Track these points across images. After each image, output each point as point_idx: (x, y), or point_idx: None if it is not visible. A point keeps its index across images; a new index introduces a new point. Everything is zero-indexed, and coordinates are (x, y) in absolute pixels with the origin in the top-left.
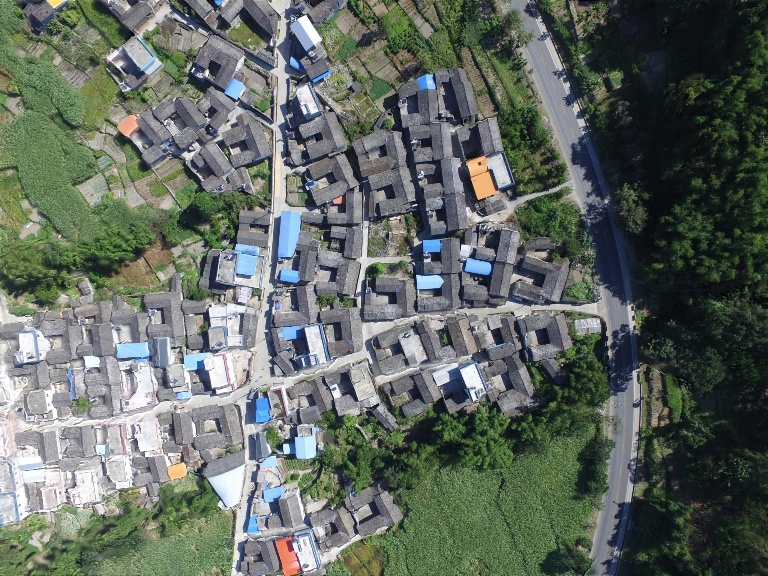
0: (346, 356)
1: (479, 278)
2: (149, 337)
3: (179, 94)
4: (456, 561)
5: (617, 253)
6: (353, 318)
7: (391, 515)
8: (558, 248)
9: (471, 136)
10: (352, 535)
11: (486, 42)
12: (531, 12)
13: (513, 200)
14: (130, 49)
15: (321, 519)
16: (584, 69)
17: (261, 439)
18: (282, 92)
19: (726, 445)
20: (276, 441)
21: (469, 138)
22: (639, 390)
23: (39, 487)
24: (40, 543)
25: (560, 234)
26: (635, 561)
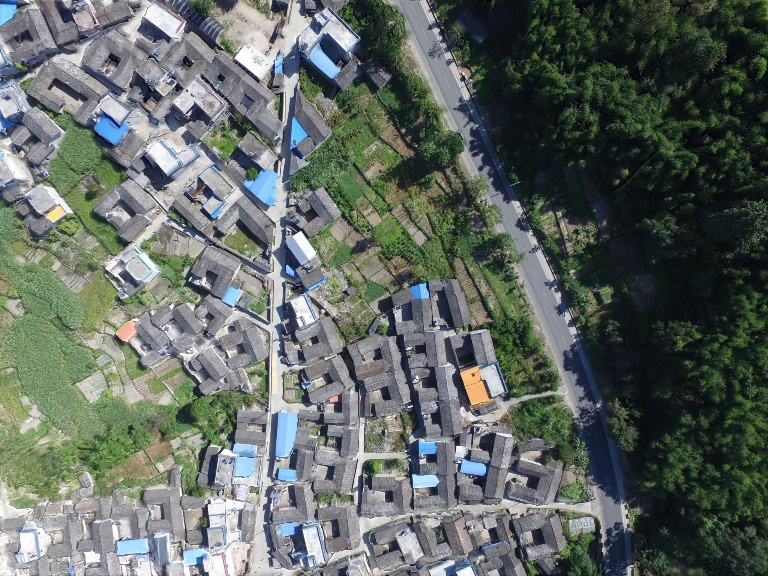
0: (344, 550)
1: (474, 477)
2: (149, 533)
3: (177, 296)
4: None
5: (610, 455)
6: (350, 517)
7: None
8: (552, 450)
9: (465, 344)
10: None
11: (478, 254)
12: (522, 226)
13: (507, 400)
14: (128, 263)
15: None
16: (575, 284)
17: None
18: (278, 296)
19: None
20: None
21: (463, 345)
22: None
23: None
24: None
25: (553, 436)
26: None
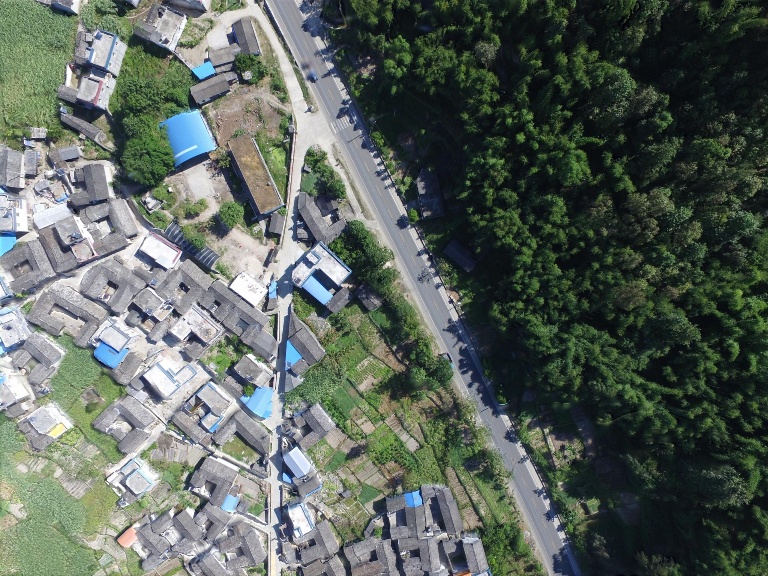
0: None
1: None
2: None
3: (176, 499)
4: None
5: None
6: None
7: None
8: None
9: (457, 549)
10: None
11: (469, 464)
12: (511, 438)
13: None
14: (128, 479)
15: None
16: (562, 495)
17: None
18: (275, 499)
19: None
20: None
21: (455, 550)
22: None
23: None
24: None
25: None
26: None
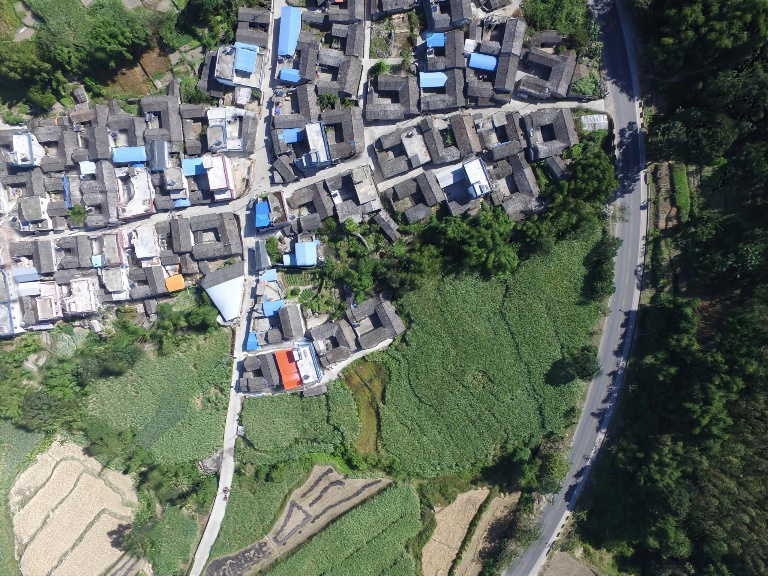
0: (347, 161)
1: (484, 76)
2: (146, 141)
3: None
4: (459, 374)
5: (625, 46)
6: (355, 117)
7: (393, 324)
8: (565, 41)
9: None
10: (353, 348)
11: None
12: None
13: None
14: None
15: (322, 331)
16: None
17: (261, 247)
18: None
19: (736, 233)
20: (276, 254)
21: None
22: (646, 191)
23: (34, 302)
24: (35, 365)
25: (567, 27)
26: (642, 366)
